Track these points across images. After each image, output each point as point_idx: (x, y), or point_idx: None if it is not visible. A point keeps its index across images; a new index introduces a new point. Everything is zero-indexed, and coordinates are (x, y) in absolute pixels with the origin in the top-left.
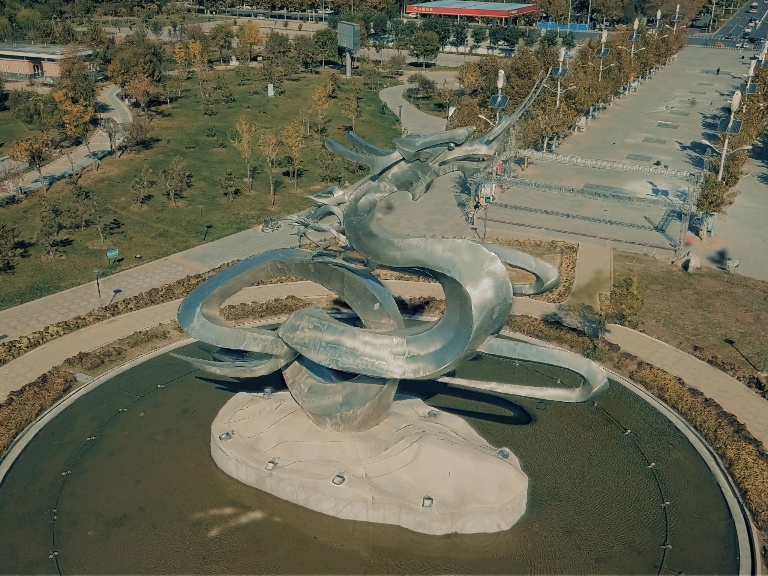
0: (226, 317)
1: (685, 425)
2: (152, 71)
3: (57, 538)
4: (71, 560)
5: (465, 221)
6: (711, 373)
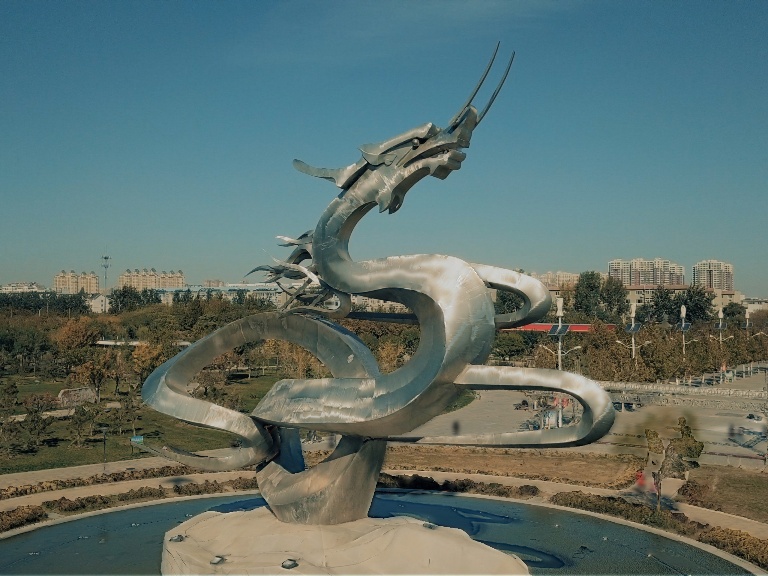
0: (234, 486)
1: (767, 574)
2: None
3: None
4: None
5: None
6: None
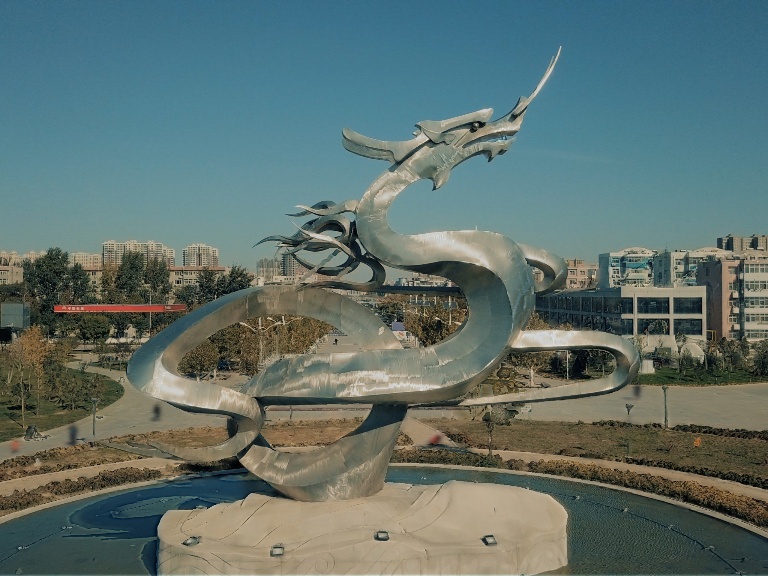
0: (55, 491)
1: (617, 486)
2: None
3: None
4: None
5: None
6: (591, 462)
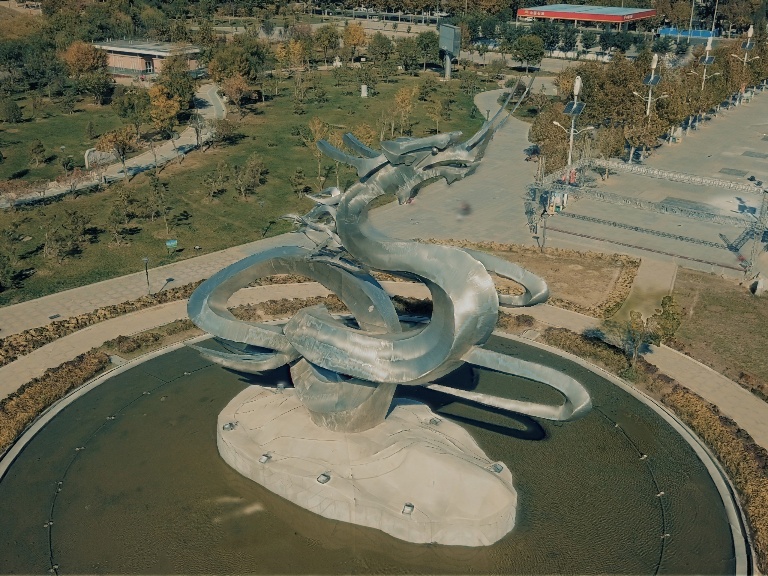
0: (265, 311)
1: (708, 455)
2: (248, 70)
3: (56, 509)
4: (64, 531)
5: (529, 229)
6: (752, 403)
